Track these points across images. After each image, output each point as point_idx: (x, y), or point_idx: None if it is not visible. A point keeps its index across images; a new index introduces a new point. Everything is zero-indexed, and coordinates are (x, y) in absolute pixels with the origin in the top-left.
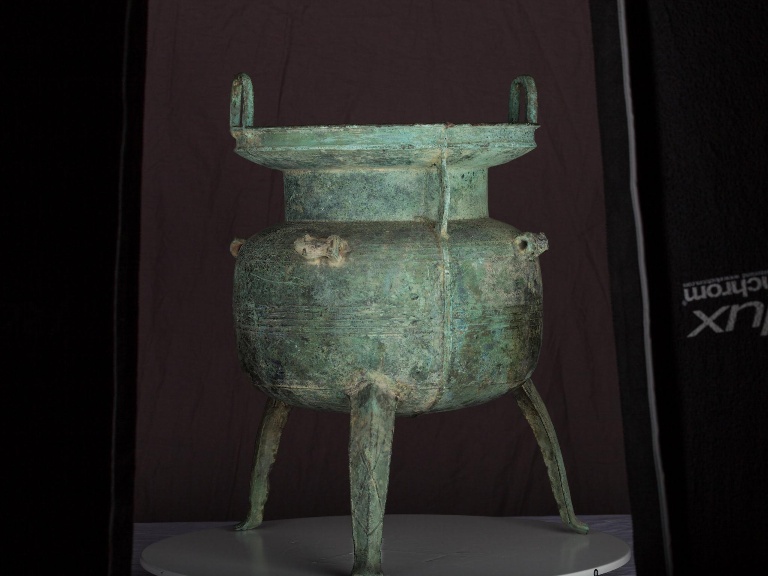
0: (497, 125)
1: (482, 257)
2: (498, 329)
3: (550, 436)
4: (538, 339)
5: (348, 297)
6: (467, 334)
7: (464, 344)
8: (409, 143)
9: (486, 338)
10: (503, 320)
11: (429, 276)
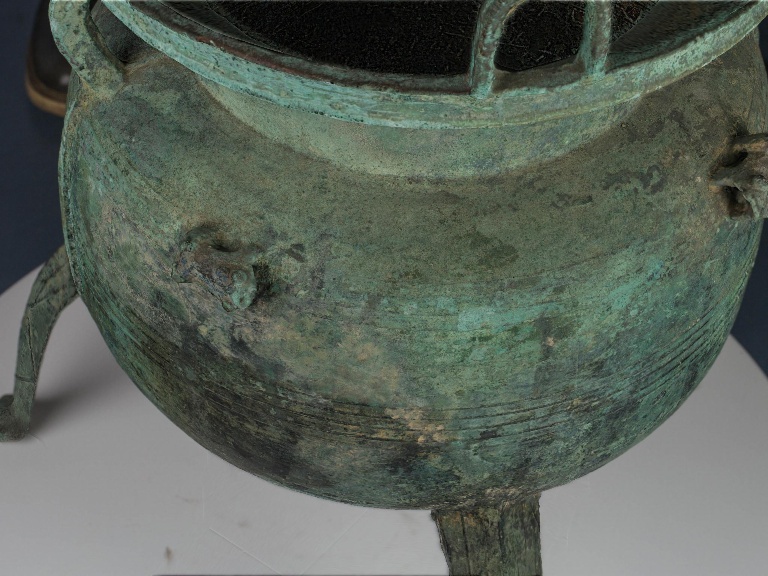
0: None
1: (105, 185)
2: (120, 327)
3: None
4: (271, 445)
5: None
6: None
7: None
8: None
9: None
10: (128, 324)
11: None
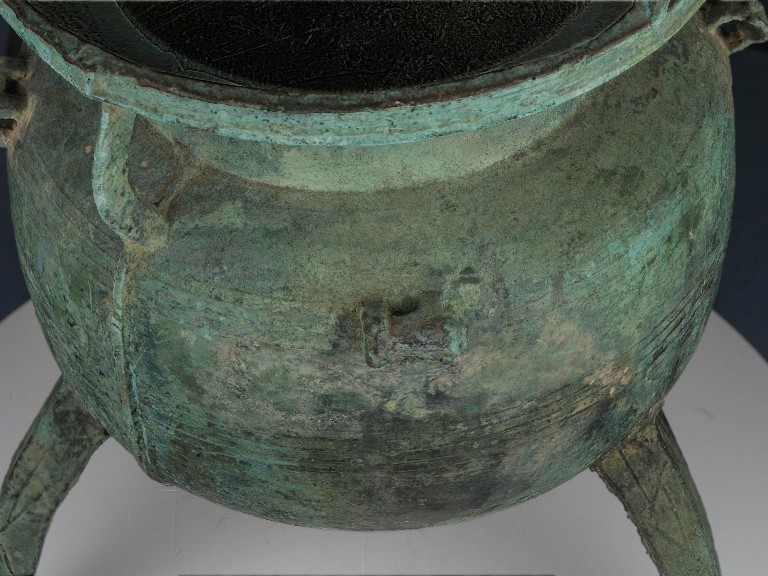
0: (226, 103)
1: (214, 328)
2: (259, 462)
3: (663, 574)
4: (471, 481)
5: (14, 221)
6: (175, 440)
7: (172, 451)
8: (32, 40)
9: (225, 464)
10: (274, 452)
11: (91, 303)
